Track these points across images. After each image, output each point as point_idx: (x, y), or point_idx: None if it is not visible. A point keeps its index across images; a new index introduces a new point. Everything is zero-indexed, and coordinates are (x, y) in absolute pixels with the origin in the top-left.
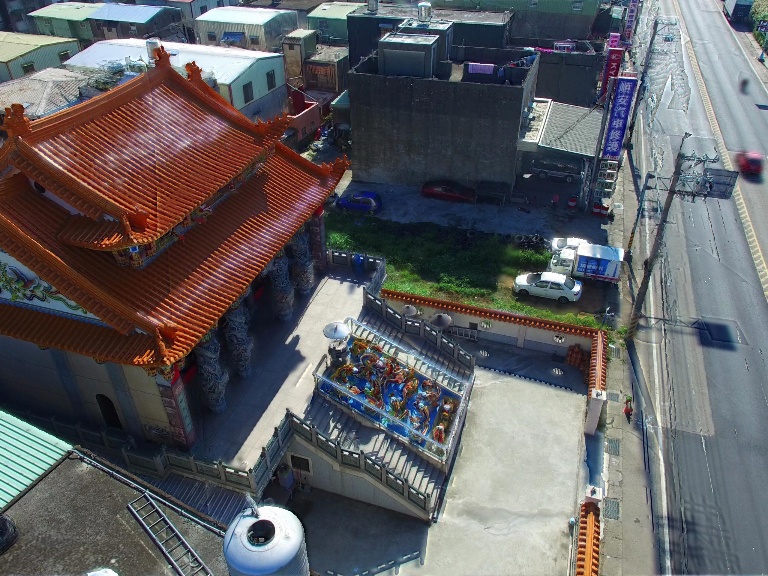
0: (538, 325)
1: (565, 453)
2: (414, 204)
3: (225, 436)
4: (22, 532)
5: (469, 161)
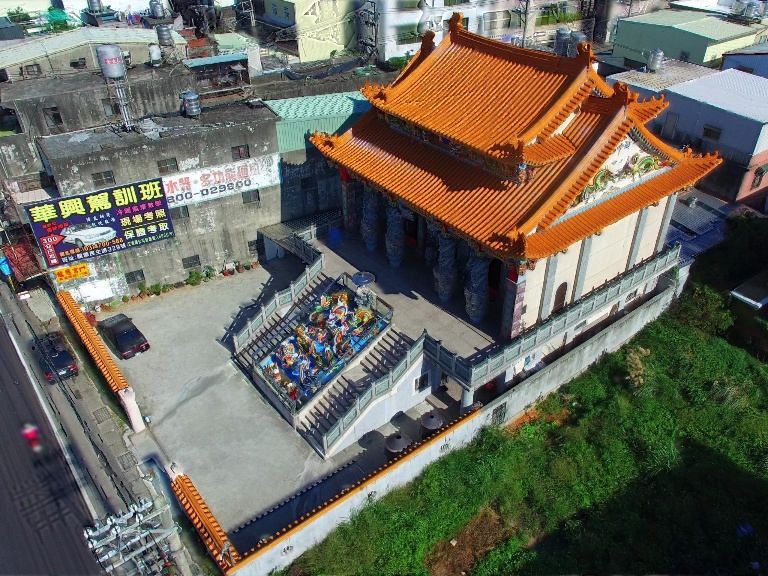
0: (307, 514)
1: (190, 464)
2: None
3: (346, 246)
4: (254, 109)
5: None
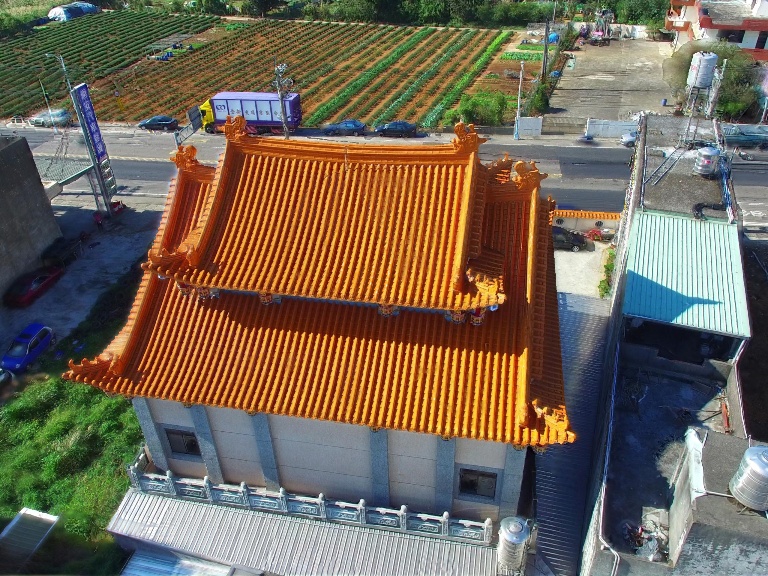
0: None
1: None
2: (43, 313)
3: None
4: None
5: (23, 243)
